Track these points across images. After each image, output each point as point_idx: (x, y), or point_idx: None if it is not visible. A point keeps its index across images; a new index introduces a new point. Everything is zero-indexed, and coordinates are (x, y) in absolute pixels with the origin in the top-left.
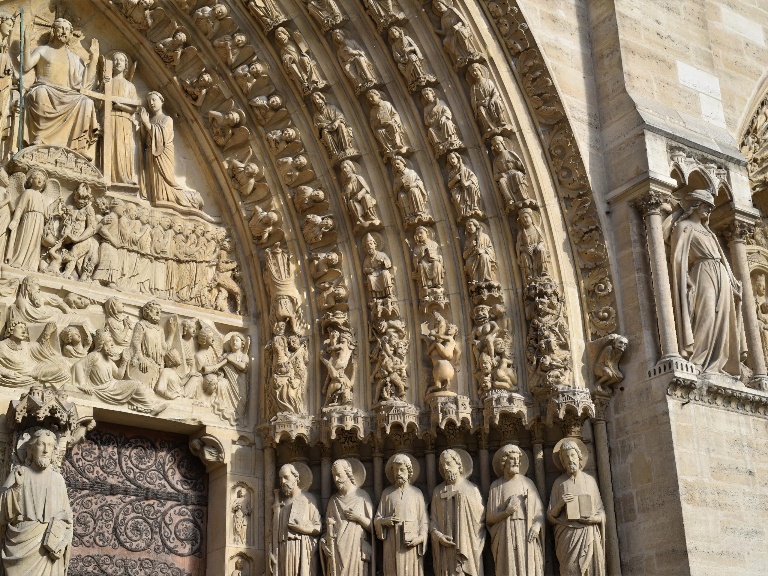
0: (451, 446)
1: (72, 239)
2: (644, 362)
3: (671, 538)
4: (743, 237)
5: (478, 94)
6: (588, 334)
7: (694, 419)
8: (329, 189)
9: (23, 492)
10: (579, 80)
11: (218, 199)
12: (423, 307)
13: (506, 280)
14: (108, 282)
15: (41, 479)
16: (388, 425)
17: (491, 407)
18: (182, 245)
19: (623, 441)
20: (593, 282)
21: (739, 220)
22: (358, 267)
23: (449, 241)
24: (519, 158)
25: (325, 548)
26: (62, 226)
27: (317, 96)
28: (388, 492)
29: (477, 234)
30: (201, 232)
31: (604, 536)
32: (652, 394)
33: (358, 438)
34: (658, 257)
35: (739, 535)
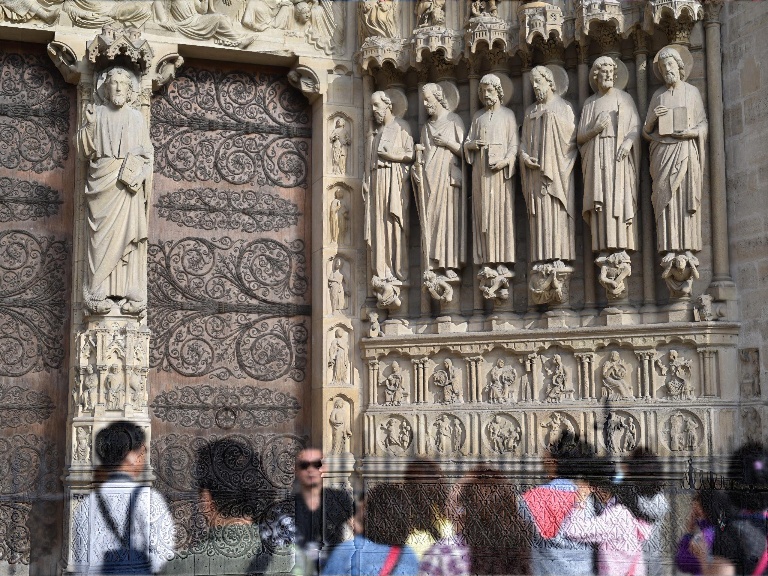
0: (546, 62)
1: None
2: None
3: None
4: None
5: None
6: None
7: None
8: None
9: (100, 130)
10: None
11: None
12: None
13: None
14: None
15: (117, 117)
16: (473, 43)
17: (581, 16)
18: None
19: (735, 45)
20: None
21: None
22: None
23: None
24: None
25: (414, 175)
26: None
27: None
28: (478, 115)
29: None
30: None
31: (702, 151)
32: None
33: (445, 59)
34: None
35: None
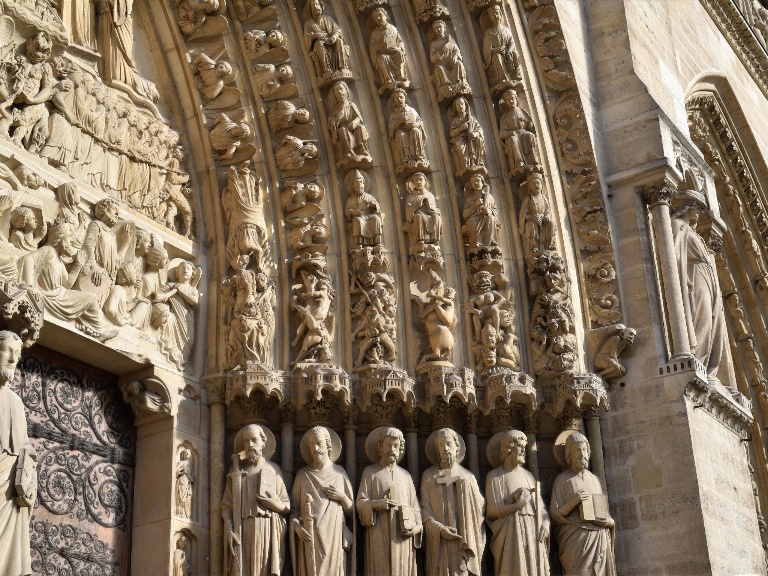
0: (441, 425)
1: (27, 98)
2: (654, 358)
3: (688, 549)
4: (712, 248)
5: (494, 40)
6: (588, 321)
7: (701, 425)
8: (312, 111)
9: None
10: (582, 52)
11: (170, 97)
12: (418, 263)
13: (507, 249)
14: (58, 164)
15: (2, 396)
16: (385, 391)
17: (502, 385)
18: (136, 140)
19: (622, 441)
20: (595, 266)
21: (714, 230)
22: (340, 206)
23: (445, 195)
24: (531, 118)
25: (302, 530)
26: (11, 79)
27: (317, 0)
28: (373, 470)
29: (483, 192)
30: (155, 130)
31: None
32: (664, 392)
33: (345, 403)
34: (670, 249)
35: (736, 553)
